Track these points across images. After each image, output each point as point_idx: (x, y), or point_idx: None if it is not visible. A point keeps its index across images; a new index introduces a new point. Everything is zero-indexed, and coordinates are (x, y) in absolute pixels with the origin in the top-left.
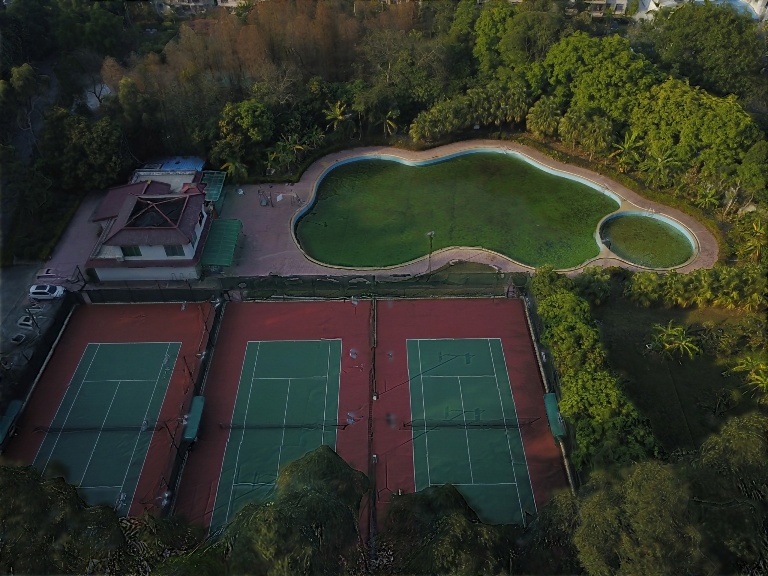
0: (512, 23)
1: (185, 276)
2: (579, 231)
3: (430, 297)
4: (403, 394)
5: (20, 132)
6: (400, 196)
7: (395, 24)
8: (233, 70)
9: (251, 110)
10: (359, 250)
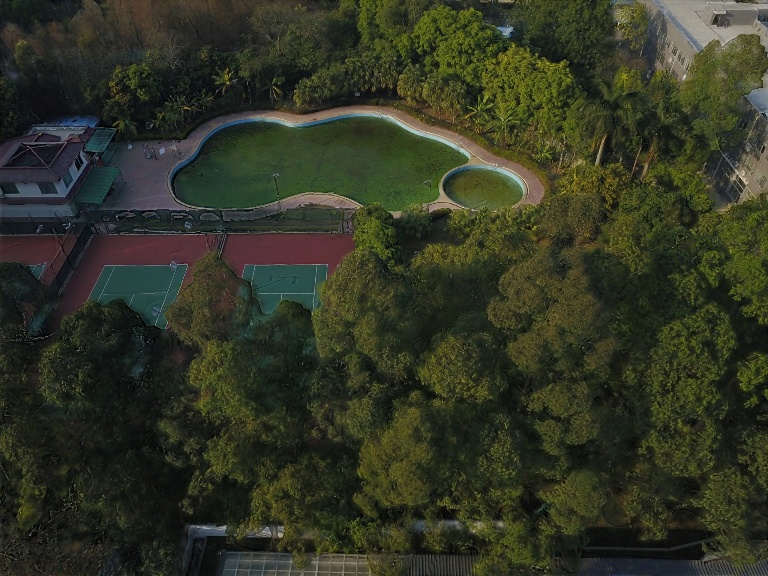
0: None
1: (62, 214)
2: None
3: (275, 232)
4: None
5: None
6: (275, 152)
7: (287, 0)
8: (132, 39)
9: (138, 72)
10: (226, 196)
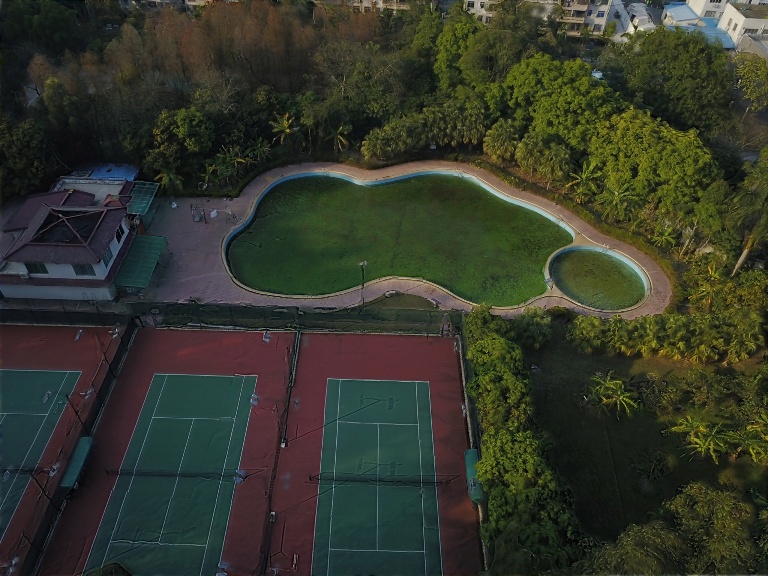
0: (474, 40)
1: (98, 297)
2: (528, 265)
3: (359, 332)
4: (315, 442)
5: None
6: (344, 217)
7: (354, 34)
8: (177, 74)
9: (188, 119)
10: (292, 275)
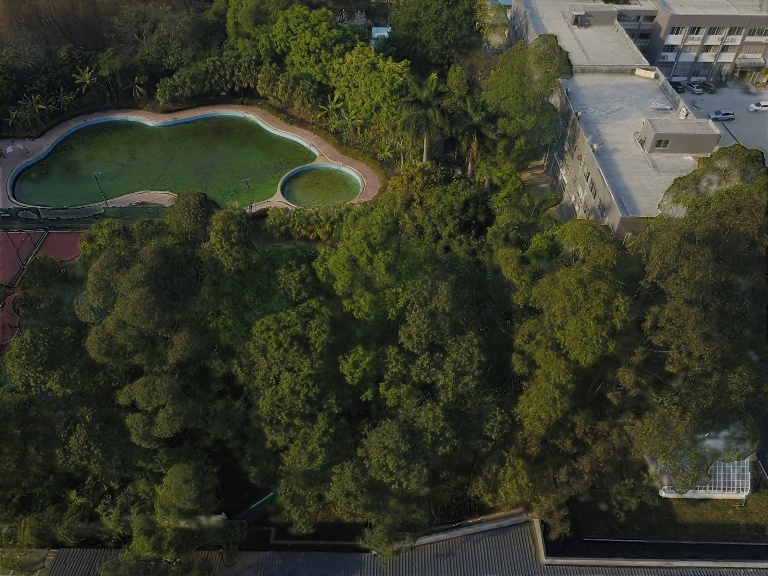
0: None
1: None
2: (269, 180)
3: None
4: None
5: None
6: (128, 151)
7: None
8: None
9: None
10: (64, 194)
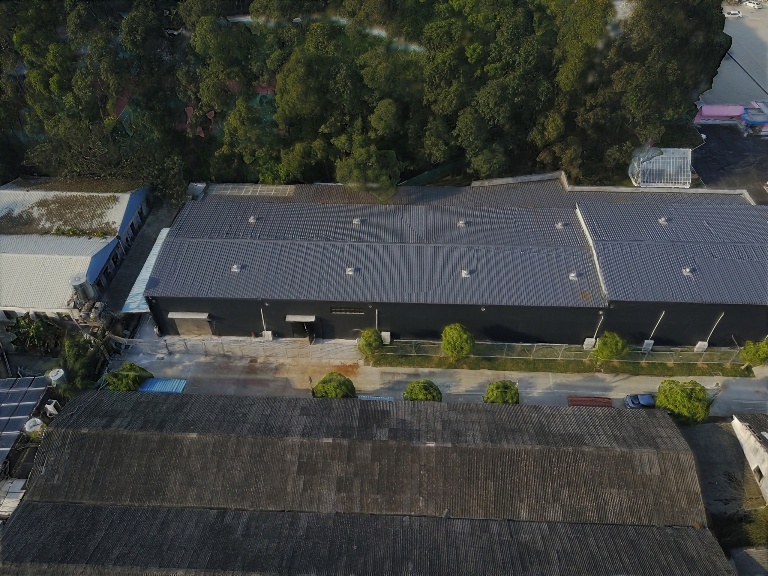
0: None
1: None
2: None
3: None
4: None
5: None
6: None
7: None
8: None
9: None
10: None
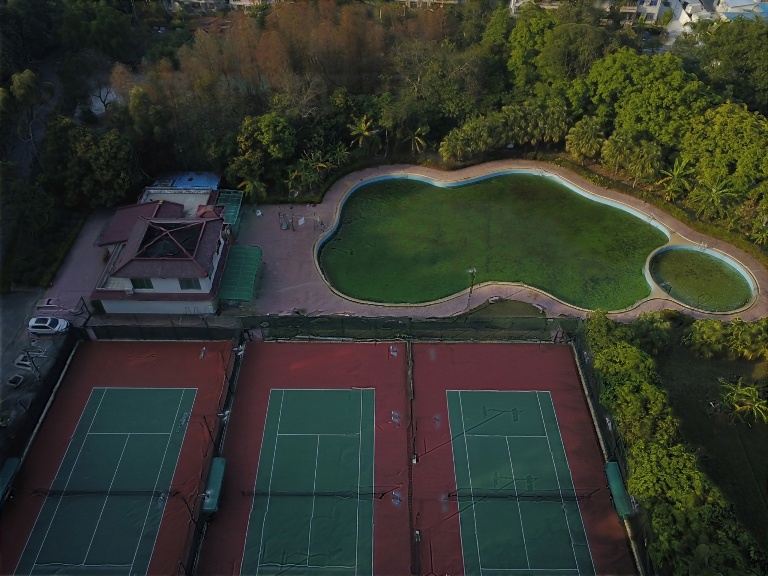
0: (552, 36)
1: (200, 310)
2: (626, 266)
3: (470, 341)
4: (446, 457)
5: (20, 143)
6: (431, 221)
7: (424, 33)
8: (251, 79)
9: (272, 125)
10: (389, 283)
